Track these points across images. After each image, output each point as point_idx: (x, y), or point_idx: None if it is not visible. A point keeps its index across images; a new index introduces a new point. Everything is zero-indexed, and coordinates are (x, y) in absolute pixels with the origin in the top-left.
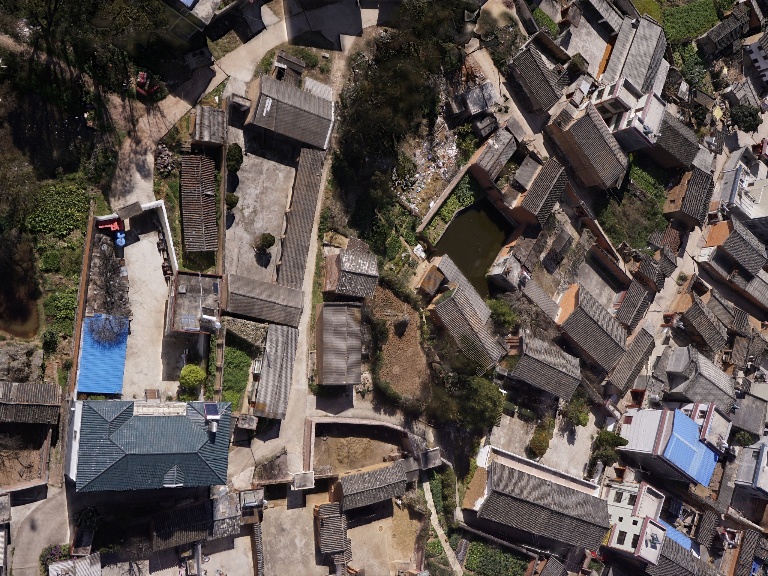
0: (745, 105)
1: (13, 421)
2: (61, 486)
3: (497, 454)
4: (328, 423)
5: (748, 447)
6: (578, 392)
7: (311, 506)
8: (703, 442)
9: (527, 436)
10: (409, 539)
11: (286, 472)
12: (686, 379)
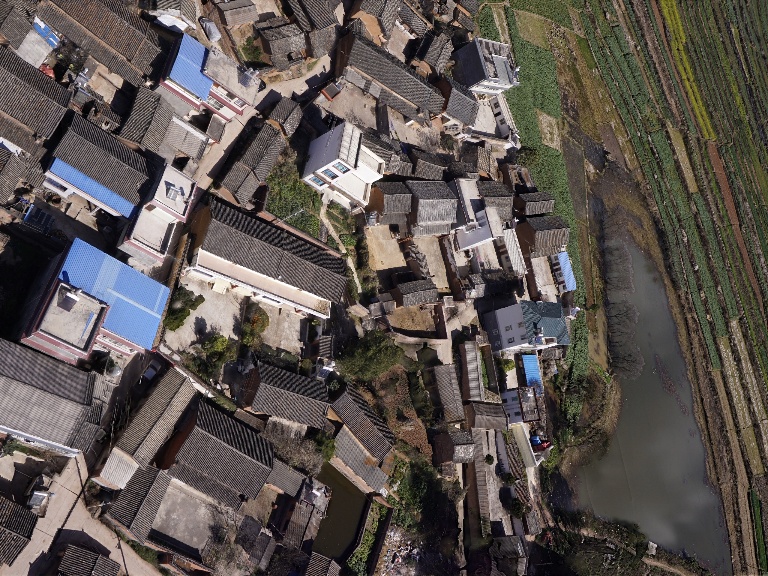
0: None
1: None
2: None
3: (316, 311)
4: None
5: None
6: None
7: None
8: (100, 302)
9: None
10: None
11: (444, 309)
12: None
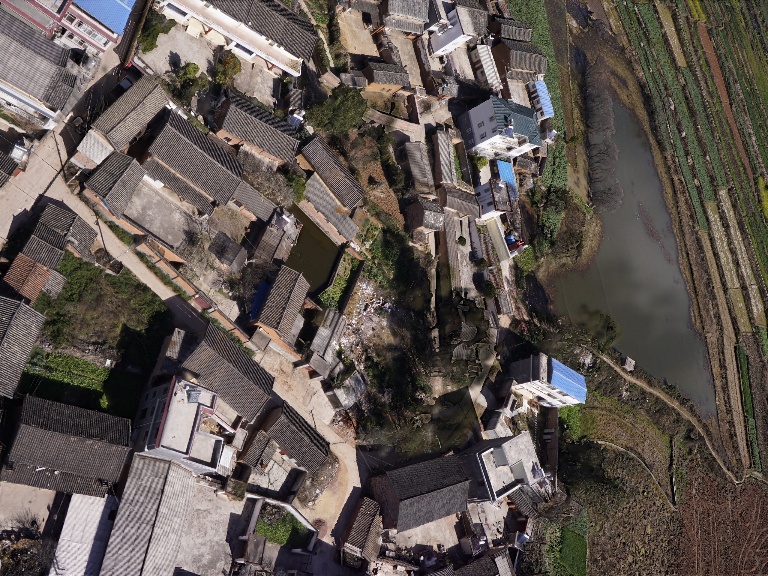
0: None
1: None
2: None
3: None
4: None
5: None
6: None
7: None
8: None
9: None
10: None
11: (417, 102)
12: None
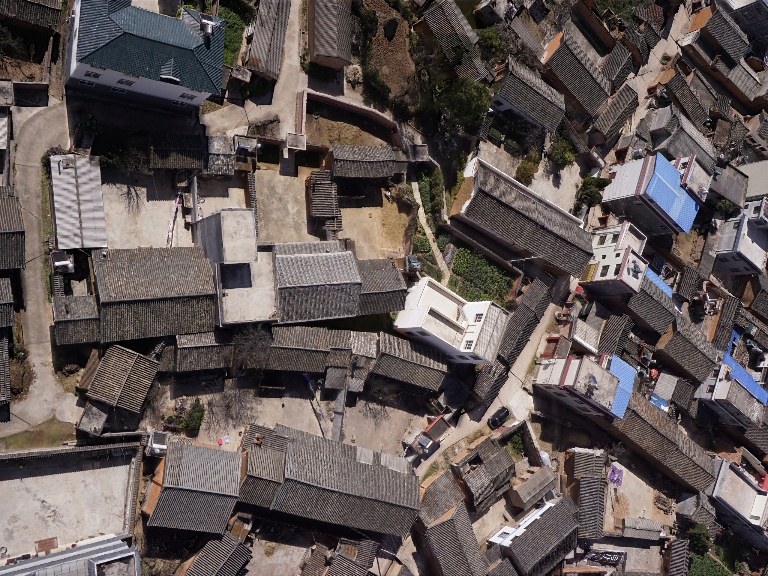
0: None
1: (16, 17)
2: (62, 99)
3: (484, 169)
4: (319, 103)
5: (729, 220)
6: (563, 135)
7: (303, 177)
8: (684, 188)
9: (513, 169)
10: (398, 232)
11: (279, 138)
12: (668, 135)
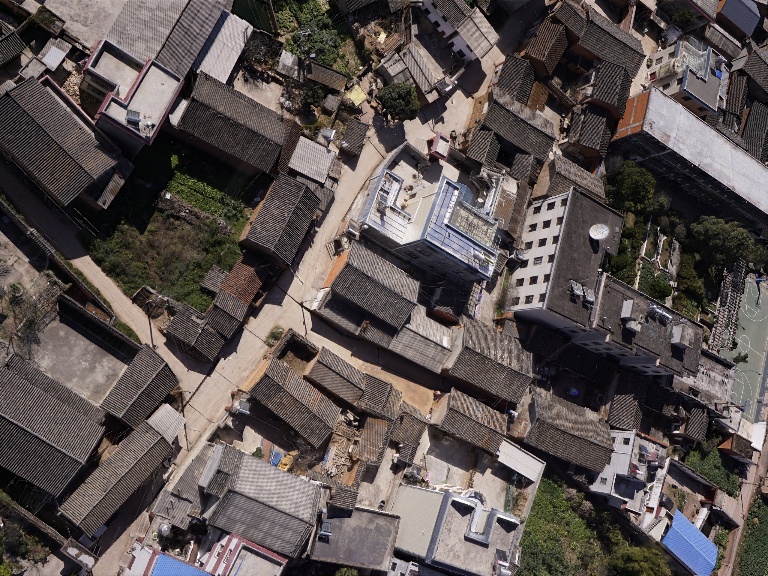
0: (393, 83)
1: None
2: None
3: None
4: None
5: None
6: (5, 530)
7: None
8: None
9: None
10: None
11: None
12: (217, 498)
